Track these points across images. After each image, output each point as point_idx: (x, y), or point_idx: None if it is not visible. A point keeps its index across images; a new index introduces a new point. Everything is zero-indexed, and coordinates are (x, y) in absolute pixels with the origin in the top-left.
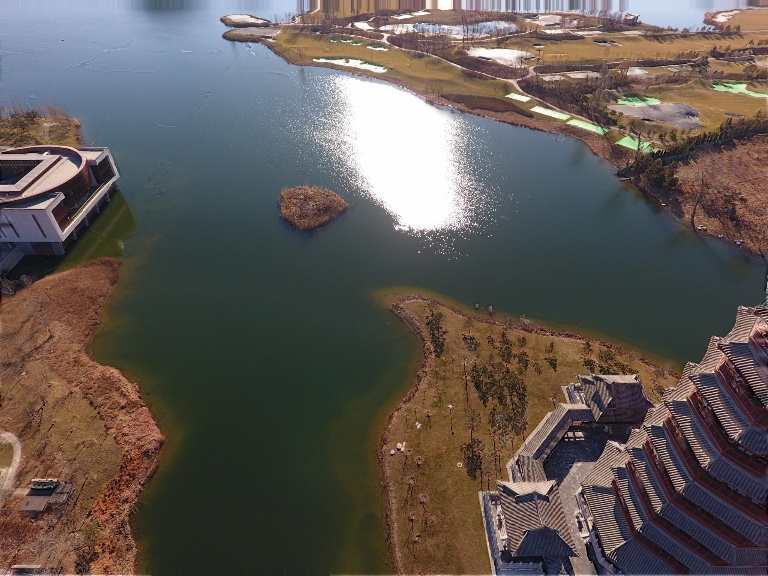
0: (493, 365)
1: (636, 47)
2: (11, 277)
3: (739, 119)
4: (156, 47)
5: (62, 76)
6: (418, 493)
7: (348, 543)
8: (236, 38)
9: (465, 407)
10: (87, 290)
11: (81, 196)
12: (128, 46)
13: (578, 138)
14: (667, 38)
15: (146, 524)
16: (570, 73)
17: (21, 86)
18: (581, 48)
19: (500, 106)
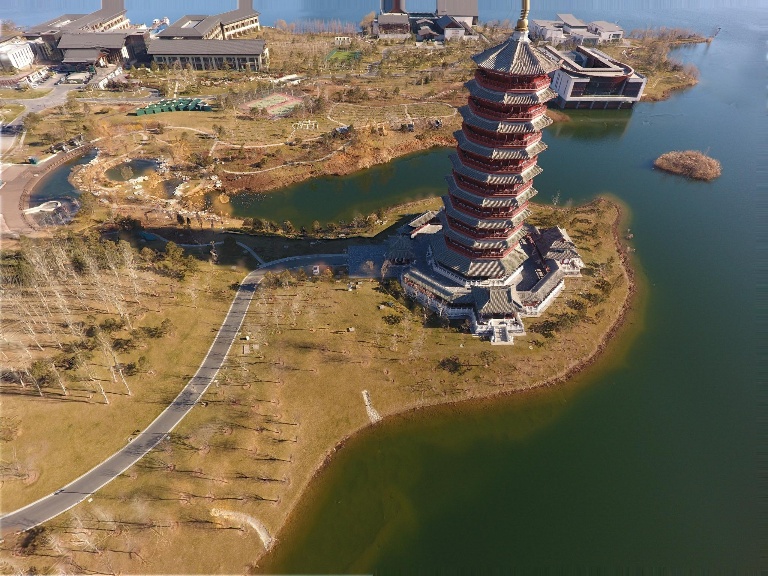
0: None
1: None
2: None
3: None
4: None
5: (754, 66)
6: None
7: None
8: None
9: None
10: None
11: (601, 90)
12: None
13: None
14: None
15: None
16: None
17: (719, 61)
18: None
19: None
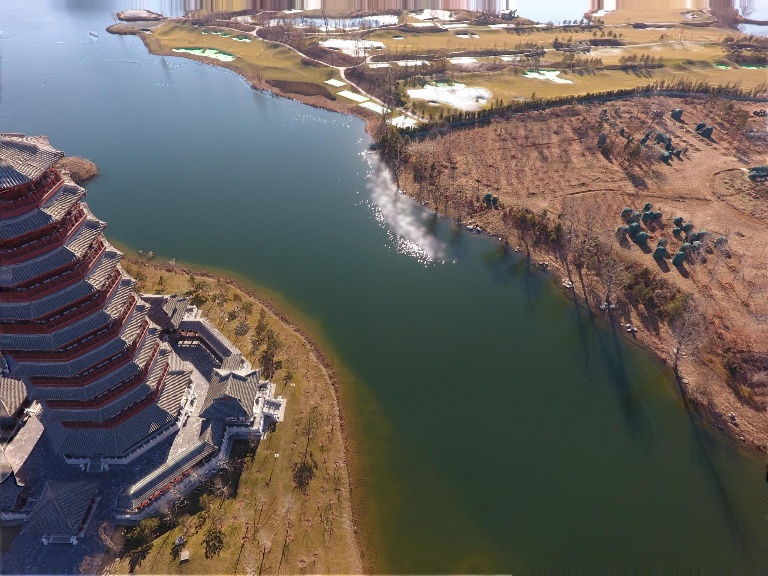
0: None
1: (490, 39)
2: None
3: (512, 101)
4: (36, 39)
5: None
6: None
7: None
8: (116, 30)
9: None
10: None
11: None
12: (11, 38)
13: (362, 118)
14: (527, 31)
15: None
16: (401, 61)
17: None
18: (437, 40)
19: (312, 90)
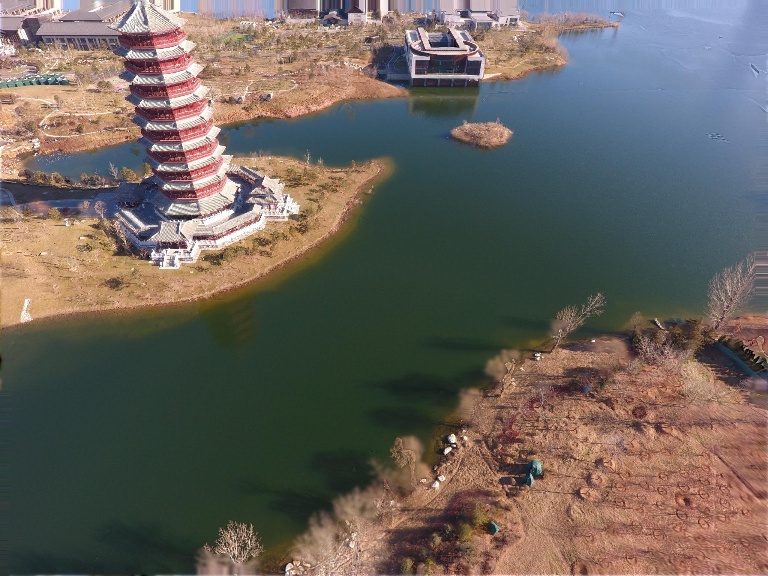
0: None
1: None
2: (394, 82)
3: None
4: (763, 63)
5: (638, 48)
6: None
7: (237, 153)
8: None
9: None
10: (379, 91)
11: (444, 68)
12: None
13: None
14: None
15: (258, 120)
16: None
17: (608, 45)
18: None
19: None
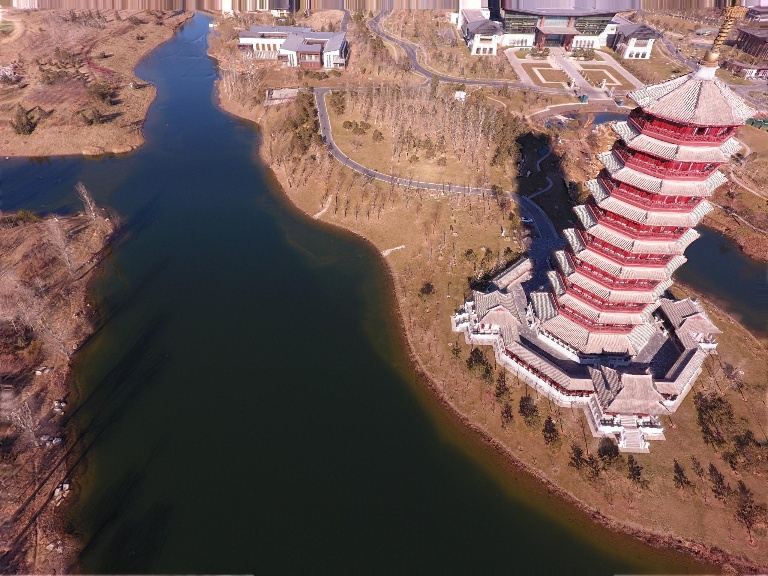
0: (759, 460)
1: None
2: None
3: None
4: None
5: None
6: (763, 361)
7: None
8: None
9: (762, 423)
10: None
11: None
12: None
13: None
14: None
15: None
16: None
17: None
18: None
19: None
